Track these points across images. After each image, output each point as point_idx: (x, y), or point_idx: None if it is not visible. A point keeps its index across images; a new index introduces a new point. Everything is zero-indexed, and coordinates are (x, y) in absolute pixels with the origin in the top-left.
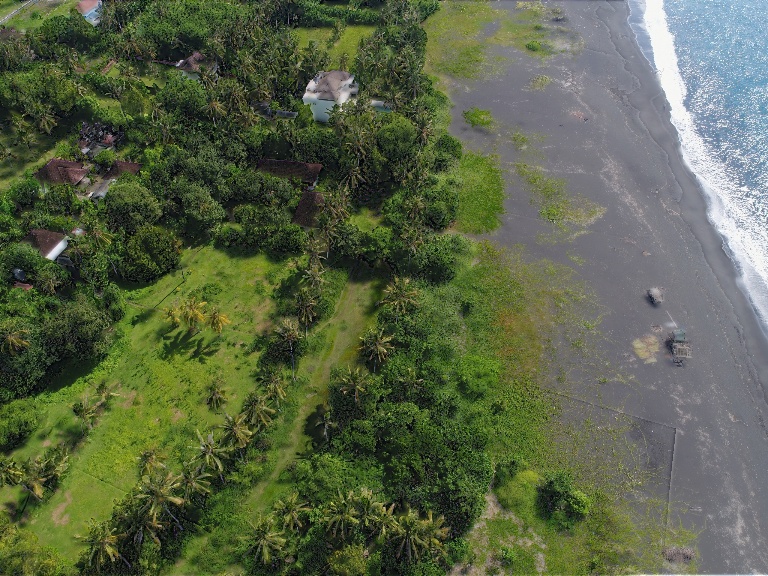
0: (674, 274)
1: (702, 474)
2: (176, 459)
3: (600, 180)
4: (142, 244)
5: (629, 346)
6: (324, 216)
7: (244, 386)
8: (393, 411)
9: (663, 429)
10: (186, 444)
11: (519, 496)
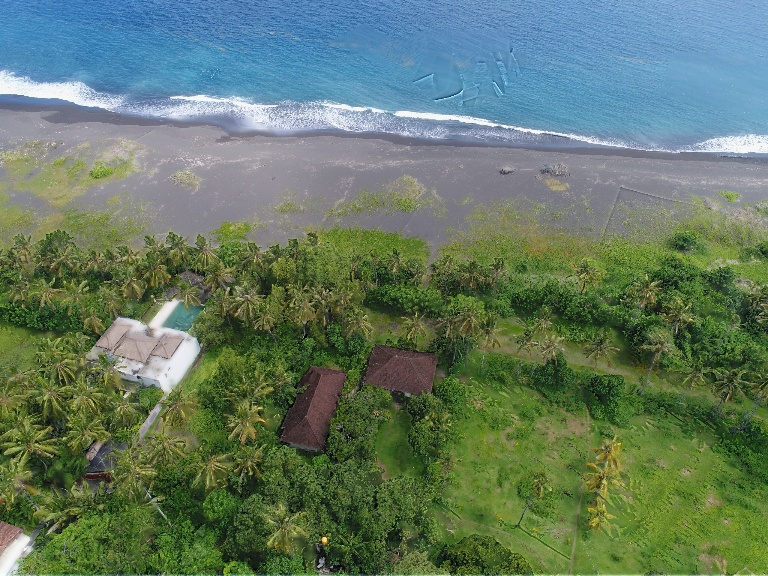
0: (480, 160)
1: (651, 185)
2: (763, 492)
3: (366, 171)
4: (493, 568)
5: (556, 192)
6: (491, 318)
7: (658, 439)
8: None
9: (623, 192)
10: (746, 482)
11: (697, 262)
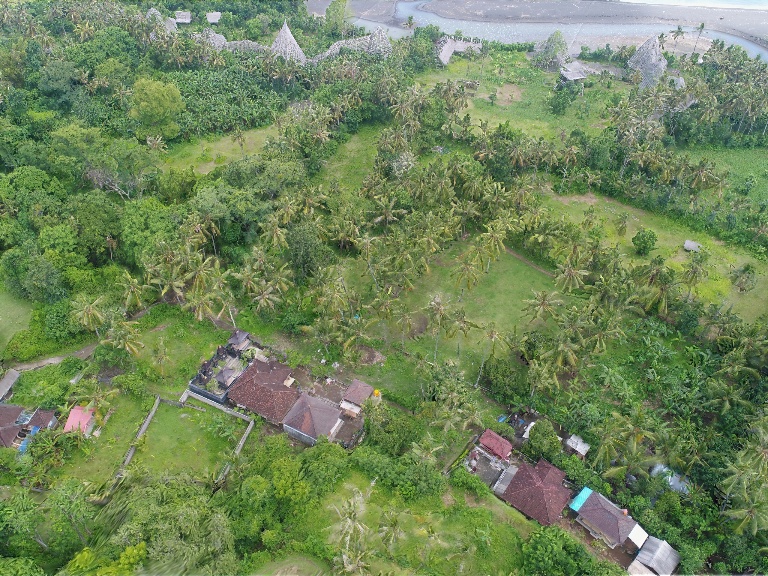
0: None
1: None
2: None
3: None
4: None
5: None
6: None
7: None
8: (23, 6)
9: None
10: None
11: None
